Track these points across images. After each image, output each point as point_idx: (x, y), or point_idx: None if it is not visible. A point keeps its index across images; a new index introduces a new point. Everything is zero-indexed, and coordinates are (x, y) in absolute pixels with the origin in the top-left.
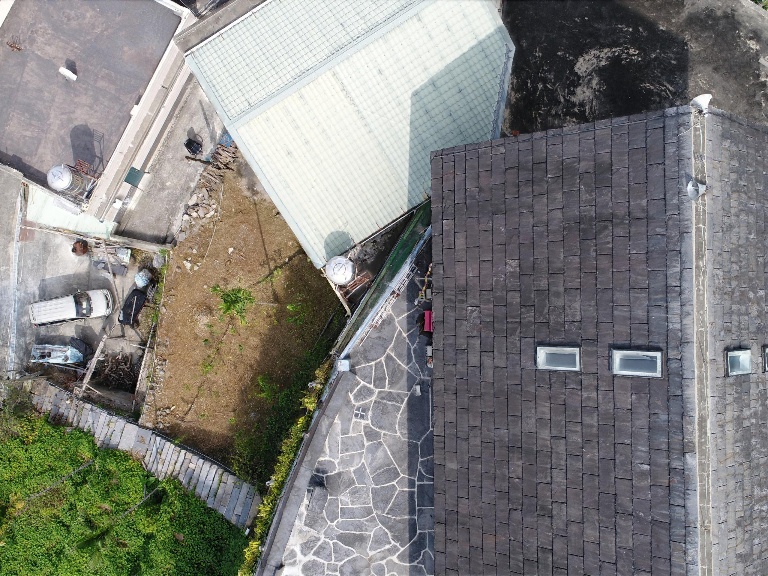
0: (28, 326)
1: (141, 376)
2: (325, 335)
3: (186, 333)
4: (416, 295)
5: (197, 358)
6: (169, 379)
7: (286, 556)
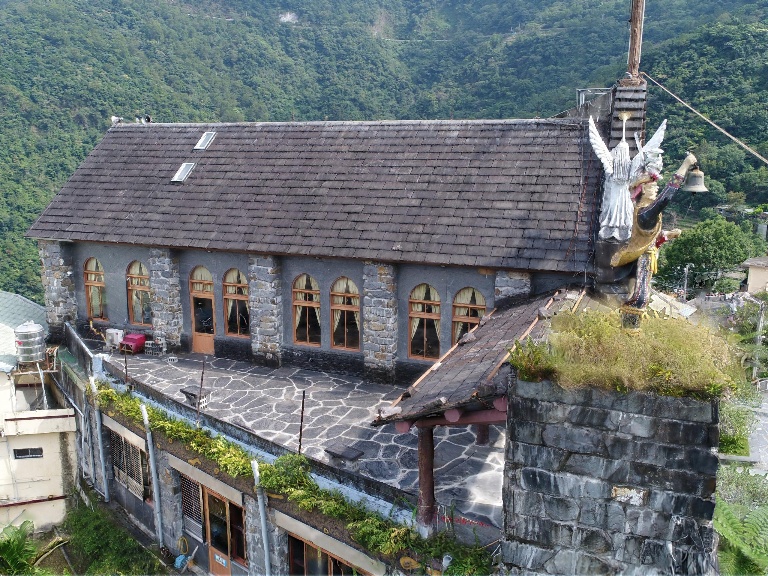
0: None
1: None
2: (71, 517)
3: None
4: (103, 352)
5: None
6: None
7: None
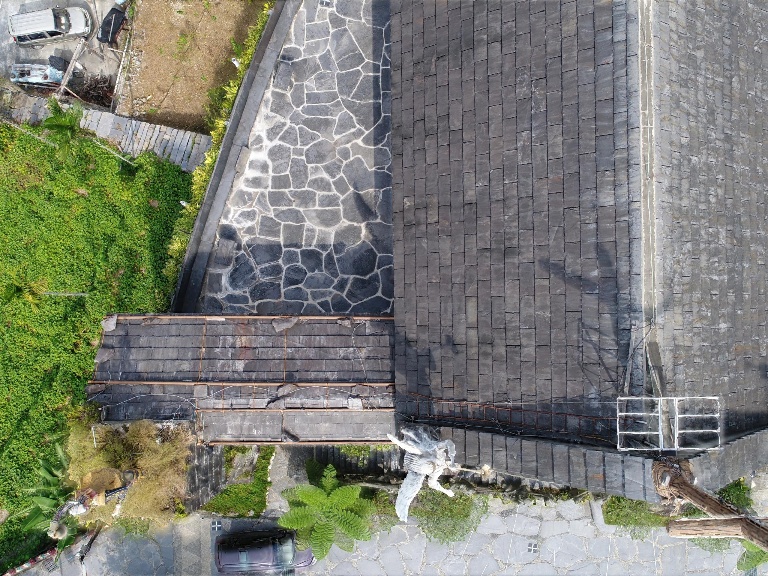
0: (8, 50)
1: (119, 80)
2: None
3: (162, 24)
4: None
5: (173, 48)
6: (145, 69)
7: (252, 141)
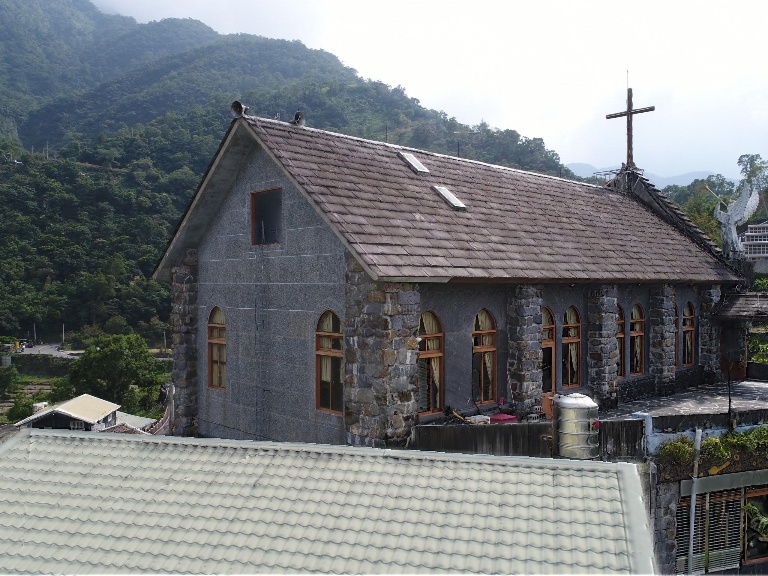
0: None
1: None
2: None
3: None
4: None
5: None
6: None
7: None
